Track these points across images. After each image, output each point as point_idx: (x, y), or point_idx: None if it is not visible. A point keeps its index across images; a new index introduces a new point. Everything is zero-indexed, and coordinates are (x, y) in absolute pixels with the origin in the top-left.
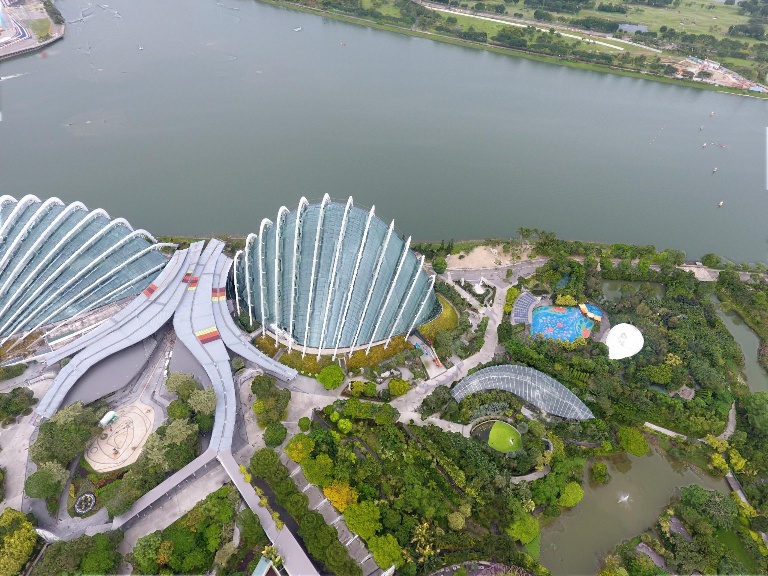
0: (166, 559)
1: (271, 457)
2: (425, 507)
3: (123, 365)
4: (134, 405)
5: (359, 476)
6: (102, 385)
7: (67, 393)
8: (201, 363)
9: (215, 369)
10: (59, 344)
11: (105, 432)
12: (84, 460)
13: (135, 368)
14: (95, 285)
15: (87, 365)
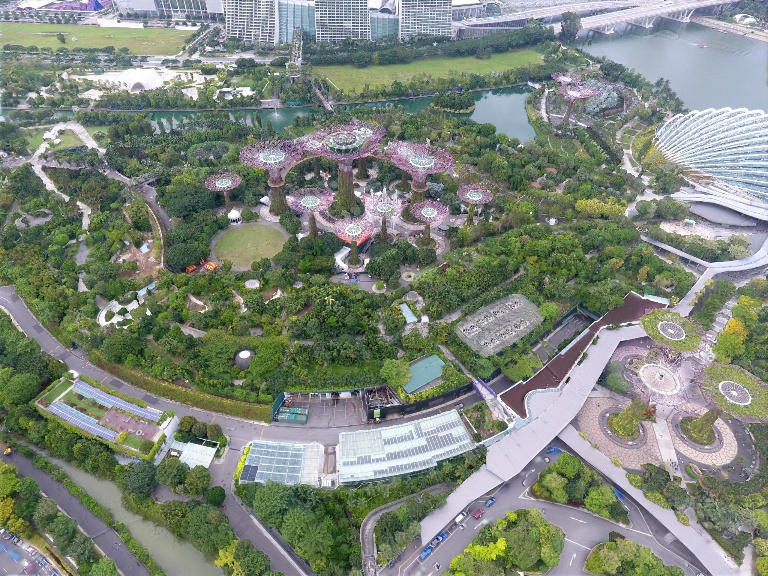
0: (647, 252)
1: (732, 287)
2: (767, 382)
3: (726, 216)
4: (705, 231)
5: (758, 338)
6: (706, 213)
7: (690, 202)
8: (763, 246)
9: (765, 254)
10: (713, 190)
11: (681, 225)
12: (661, 222)
13: (729, 222)
14: (767, 185)
15: (713, 201)
